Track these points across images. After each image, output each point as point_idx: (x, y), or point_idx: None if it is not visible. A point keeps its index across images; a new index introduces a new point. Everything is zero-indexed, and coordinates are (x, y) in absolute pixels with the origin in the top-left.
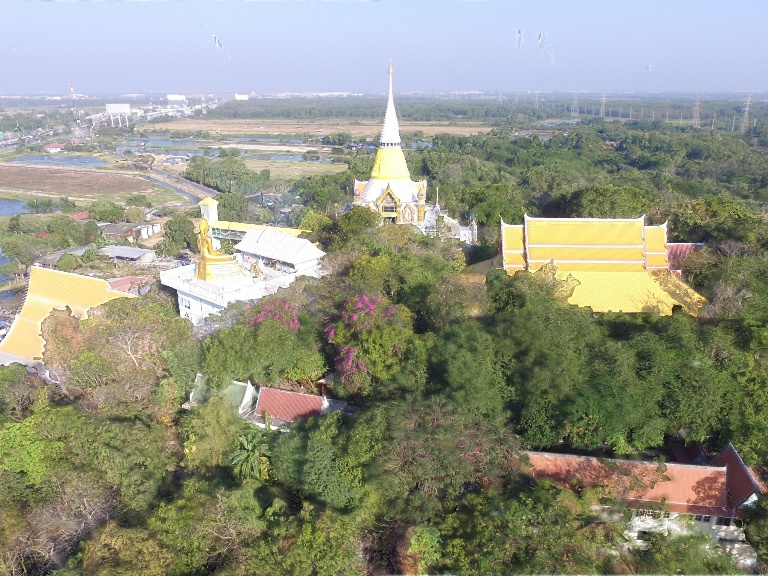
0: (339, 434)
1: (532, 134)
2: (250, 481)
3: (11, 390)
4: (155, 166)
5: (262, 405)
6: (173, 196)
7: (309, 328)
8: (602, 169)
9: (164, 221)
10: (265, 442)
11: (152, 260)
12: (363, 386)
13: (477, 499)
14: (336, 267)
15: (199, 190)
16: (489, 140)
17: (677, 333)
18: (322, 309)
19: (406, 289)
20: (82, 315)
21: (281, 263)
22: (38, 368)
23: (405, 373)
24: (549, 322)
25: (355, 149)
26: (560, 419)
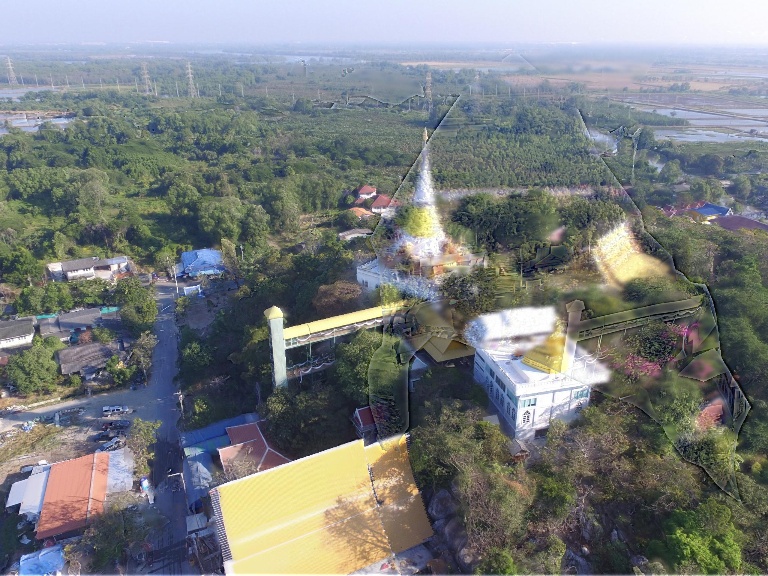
0: None
1: (44, 124)
2: (756, 466)
3: (541, 568)
4: None
5: None
6: None
7: None
8: (183, 157)
9: None
10: None
11: None
12: None
13: None
14: None
15: None
16: (23, 140)
17: (750, 283)
18: None
19: None
20: (342, 496)
21: None
22: None
23: None
24: None
25: None
26: None
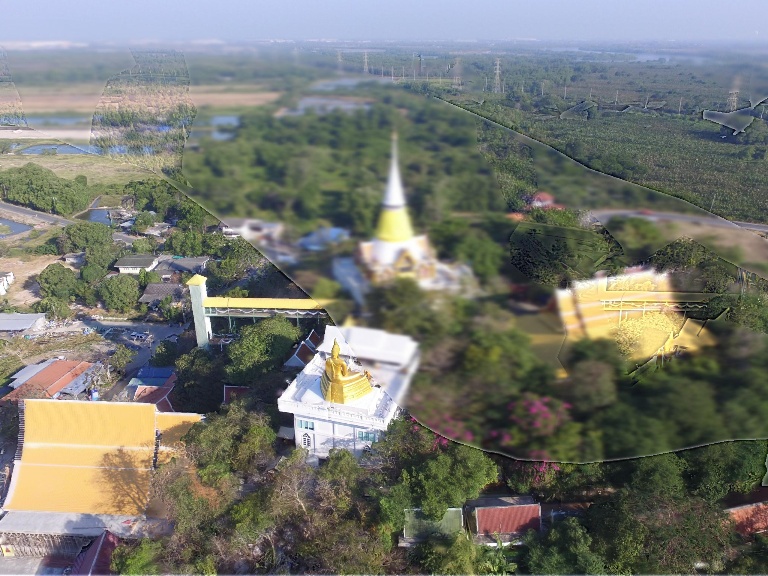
0: (596, 542)
1: None
2: None
3: (166, 575)
4: None
5: (482, 525)
6: None
7: None
8: None
9: (3, 264)
10: (511, 562)
11: (45, 327)
12: (549, 481)
13: (743, 571)
14: None
15: (5, 210)
16: None
17: None
18: None
19: None
20: (124, 447)
21: None
22: (89, 521)
23: None
24: None
25: None
26: (733, 480)
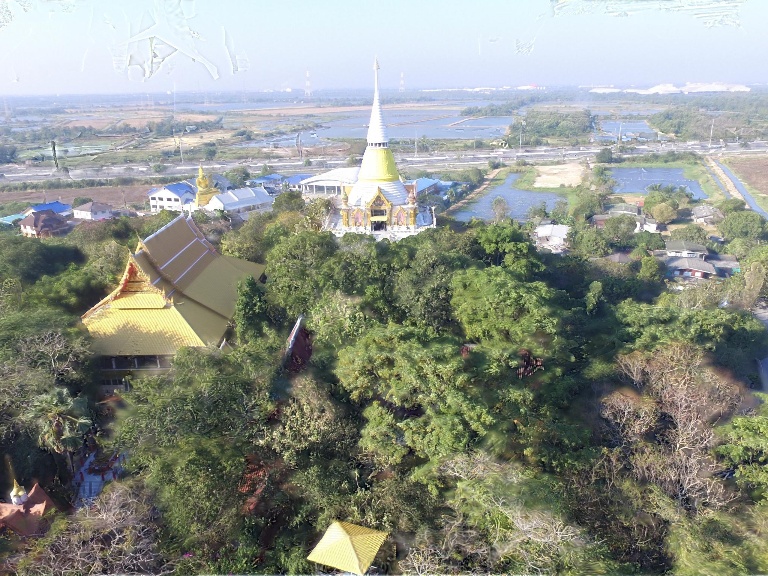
0: None
1: None
2: None
3: None
4: None
5: None
6: None
7: None
8: None
9: None
10: None
11: (553, 244)
12: None
13: None
14: None
15: None
16: None
17: None
18: None
19: None
20: None
21: None
22: None
23: None
24: None
25: None
26: None
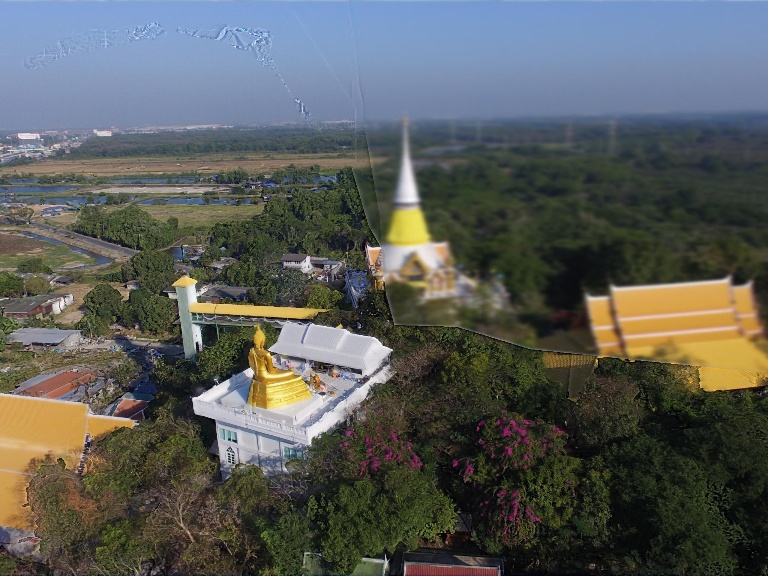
0: None
1: None
2: None
3: None
4: (33, 219)
5: None
6: (69, 255)
7: (432, 464)
8: None
9: (72, 289)
10: None
11: (78, 343)
12: (527, 538)
13: None
14: (415, 368)
15: (99, 246)
16: None
17: None
18: (439, 435)
19: (519, 392)
20: (51, 452)
21: (342, 368)
22: None
23: (582, 516)
24: (762, 438)
25: (255, 187)
26: None
